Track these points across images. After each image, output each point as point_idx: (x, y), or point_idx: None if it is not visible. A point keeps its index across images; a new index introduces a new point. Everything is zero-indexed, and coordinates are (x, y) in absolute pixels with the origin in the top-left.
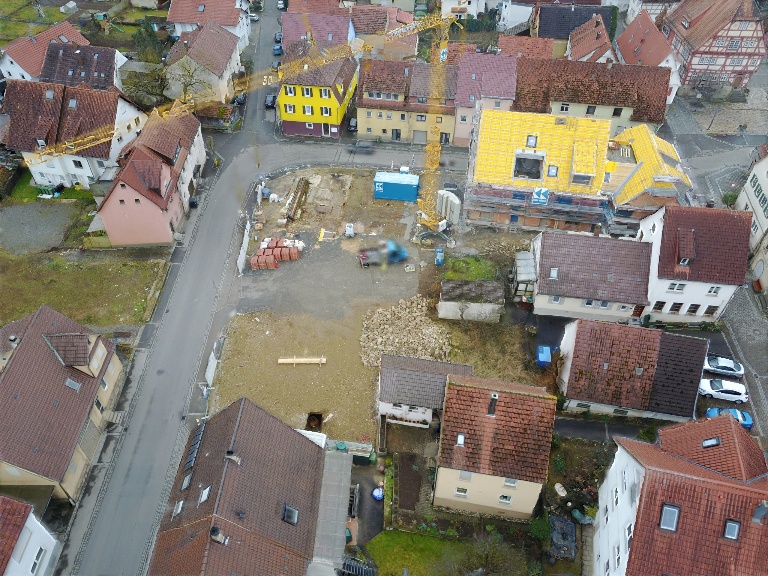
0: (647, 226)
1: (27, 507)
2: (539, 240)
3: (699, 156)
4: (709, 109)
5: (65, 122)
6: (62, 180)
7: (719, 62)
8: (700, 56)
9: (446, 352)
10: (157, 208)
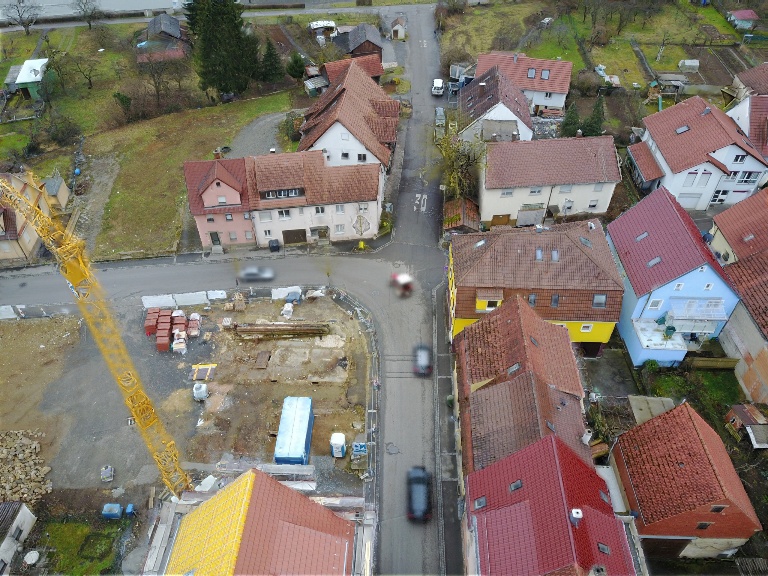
0: None
1: None
2: None
3: None
4: None
5: None
6: None
7: None
8: None
9: None
10: None
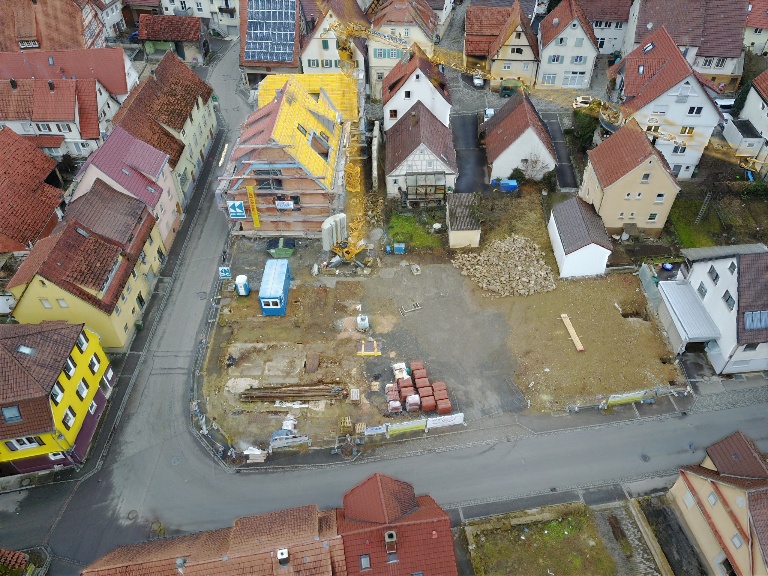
0: (397, 101)
1: None
2: (411, 158)
3: (218, 103)
4: None
5: None
6: None
7: None
8: None
9: None
10: None
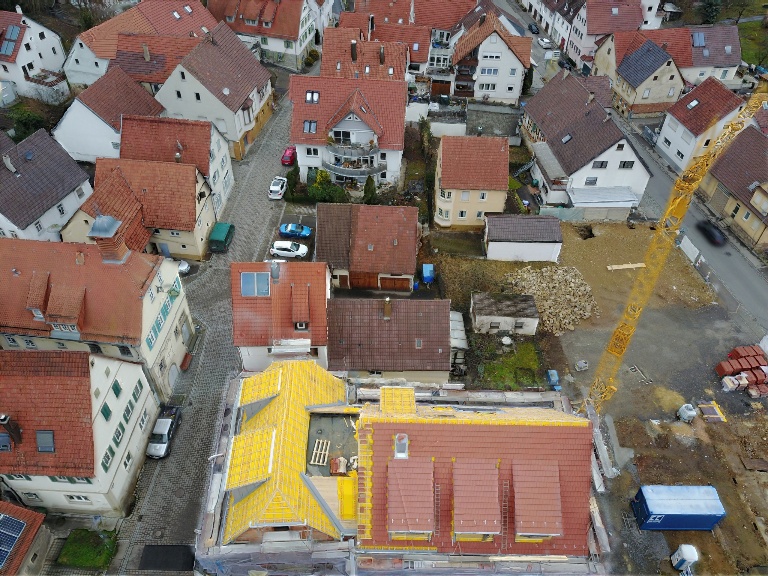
0: None
1: None
2: None
3: None
4: None
5: None
6: None
7: None
8: None
9: None
10: None
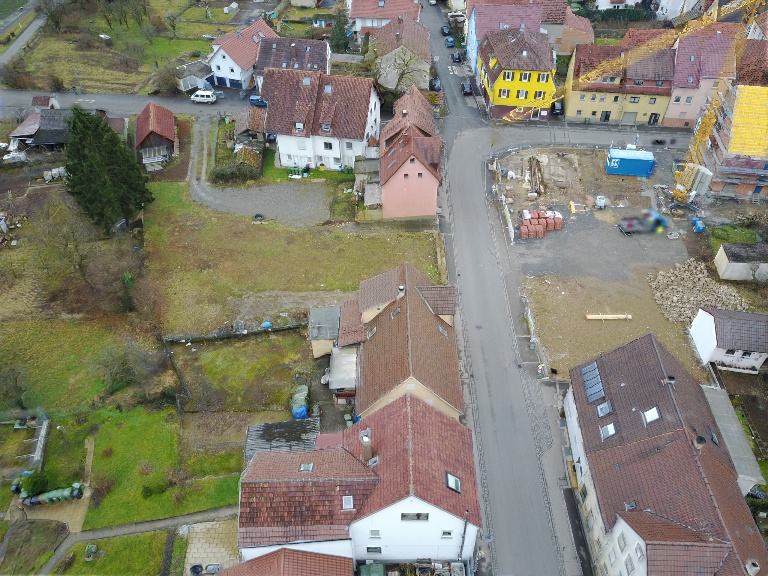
0: None
1: (469, 430)
2: None
3: None
4: None
5: (320, 107)
6: (308, 162)
7: None
8: None
9: (745, 308)
10: (435, 181)
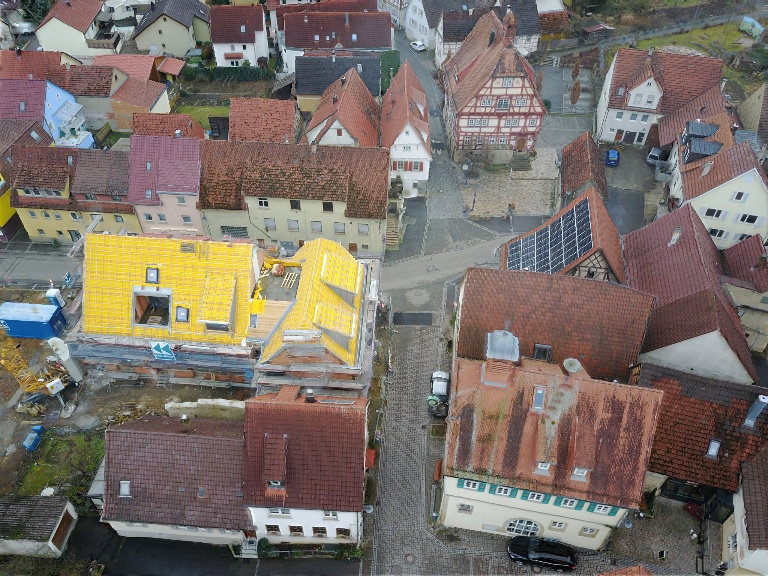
0: None
1: None
2: None
3: (448, 251)
4: (484, 180)
5: None
6: None
7: (492, 123)
8: (467, 117)
9: None
10: None
